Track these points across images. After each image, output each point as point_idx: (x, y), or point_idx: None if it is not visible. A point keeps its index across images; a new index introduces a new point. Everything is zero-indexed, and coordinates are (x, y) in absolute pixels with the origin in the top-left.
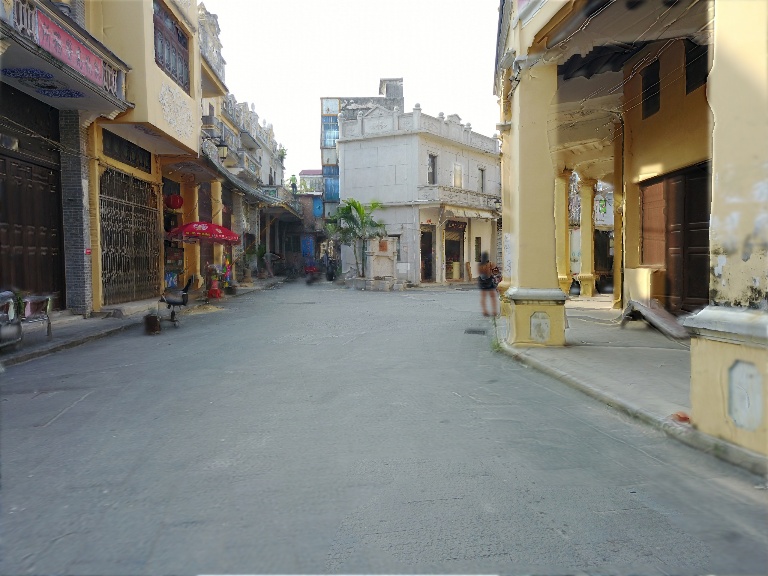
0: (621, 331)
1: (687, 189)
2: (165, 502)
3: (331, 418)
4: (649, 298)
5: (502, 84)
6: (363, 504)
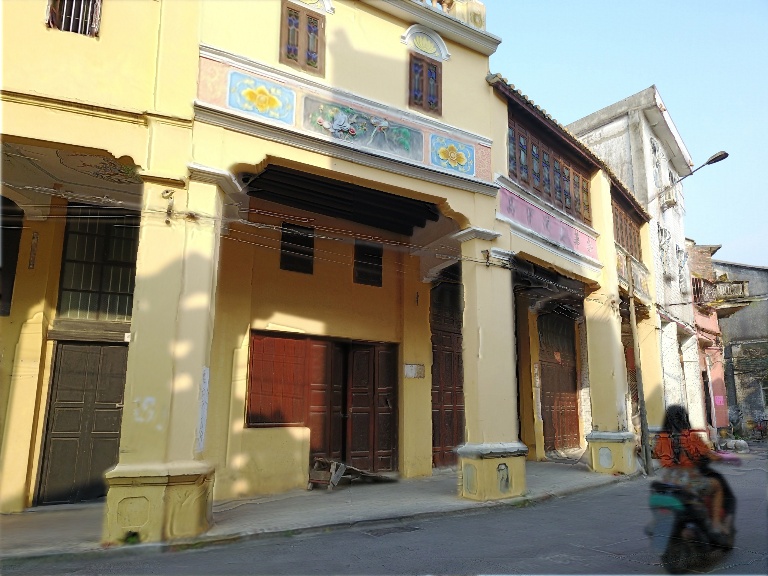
0: (375, 488)
1: (333, 355)
2: None
3: (759, 495)
4: (307, 458)
5: (291, 145)
6: (767, 485)
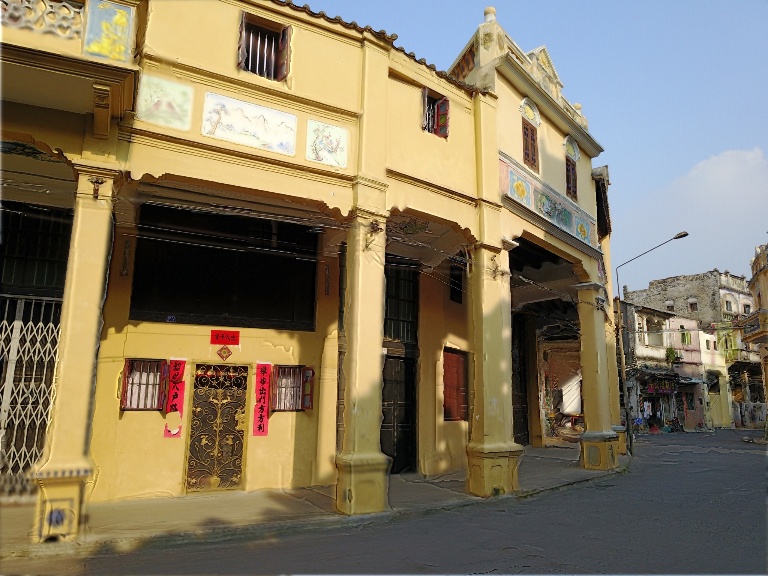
0: None
1: None
2: (759, 460)
3: None
4: None
5: (532, 223)
6: None
